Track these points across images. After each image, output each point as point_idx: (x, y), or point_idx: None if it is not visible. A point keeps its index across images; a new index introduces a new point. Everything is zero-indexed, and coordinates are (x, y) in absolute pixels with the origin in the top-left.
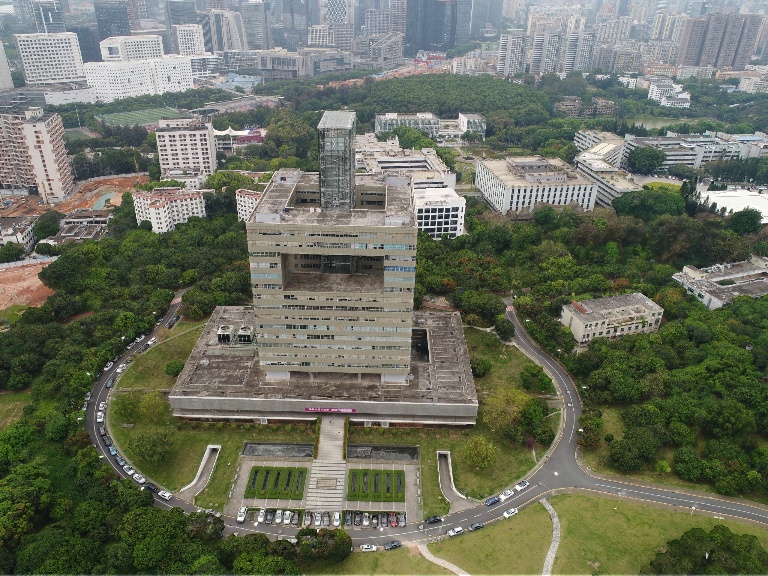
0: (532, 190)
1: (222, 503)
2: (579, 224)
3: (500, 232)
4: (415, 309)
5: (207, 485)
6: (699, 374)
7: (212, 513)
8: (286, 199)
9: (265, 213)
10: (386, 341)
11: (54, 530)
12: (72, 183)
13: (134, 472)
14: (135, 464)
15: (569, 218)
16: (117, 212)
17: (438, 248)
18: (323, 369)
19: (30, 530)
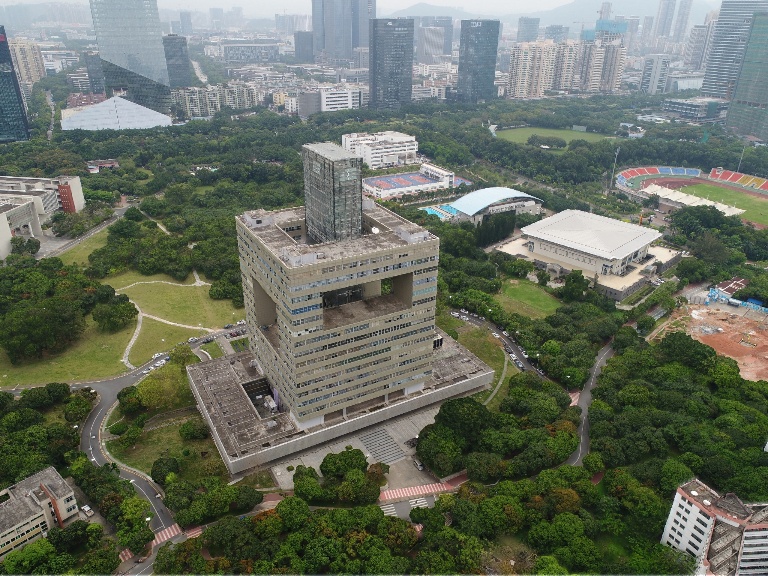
0: None
1: None
2: None
3: None
4: None
5: None
6: None
7: None
8: None
9: None
10: None
11: None
12: None
13: None
14: None
15: None
16: None
17: None
18: None
19: None
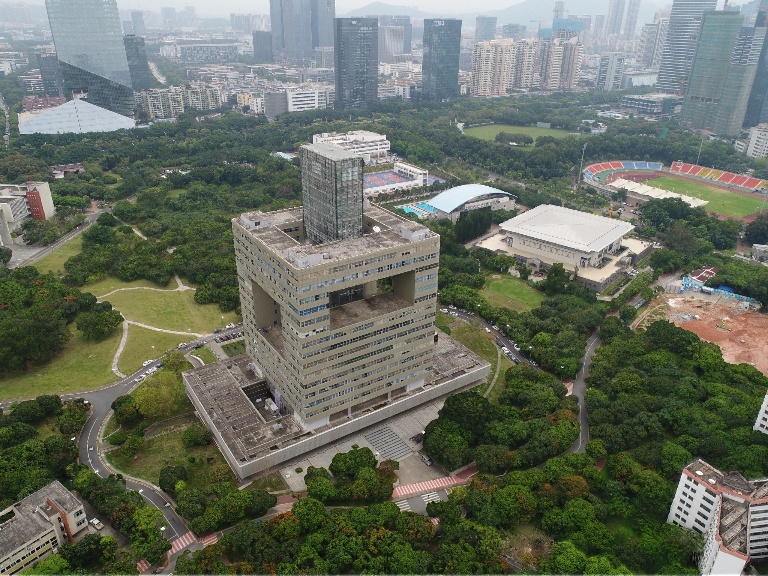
0: None
1: None
2: None
3: None
4: None
5: None
6: None
7: None
8: None
9: None
10: None
11: None
12: None
13: None
14: None
15: None
16: None
17: None
18: None
19: None
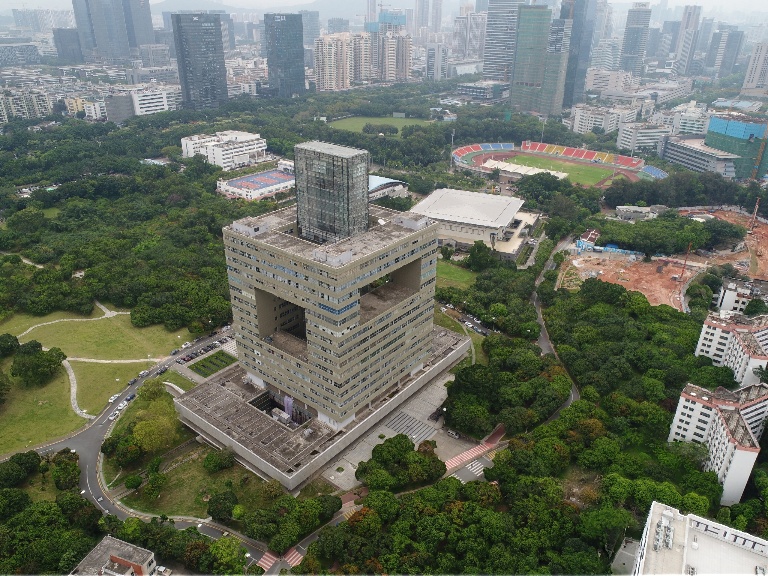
0: None
1: None
2: None
3: None
4: None
5: None
6: None
7: None
8: None
9: None
10: None
11: None
12: None
13: None
14: None
15: None
16: None
17: None
18: None
19: None
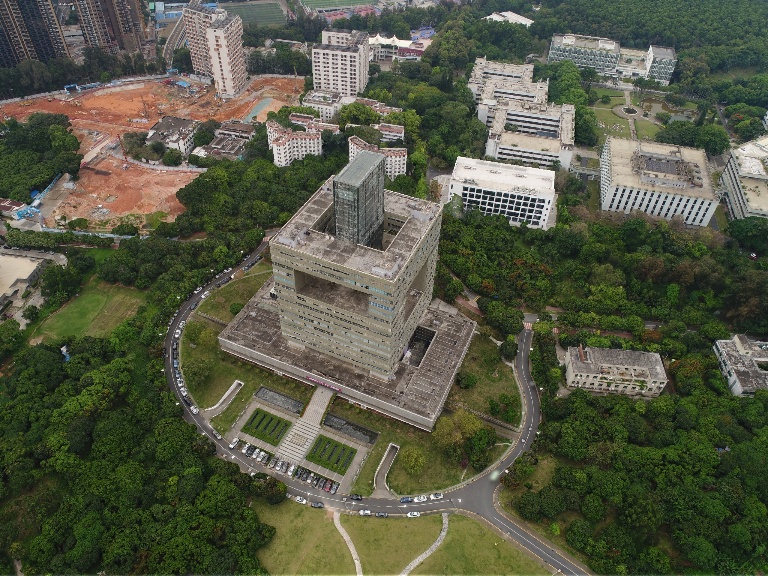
0: (639, 192)
1: (226, 429)
2: (668, 245)
3: (572, 239)
4: (448, 302)
5: (222, 412)
6: (651, 459)
7: (216, 435)
8: (318, 216)
9: (285, 237)
10: (371, 350)
11: (121, 414)
12: (244, 80)
13: (183, 385)
14: (186, 379)
15: (660, 236)
16: (258, 132)
17: (504, 240)
18: (326, 352)
19: (109, 408)
